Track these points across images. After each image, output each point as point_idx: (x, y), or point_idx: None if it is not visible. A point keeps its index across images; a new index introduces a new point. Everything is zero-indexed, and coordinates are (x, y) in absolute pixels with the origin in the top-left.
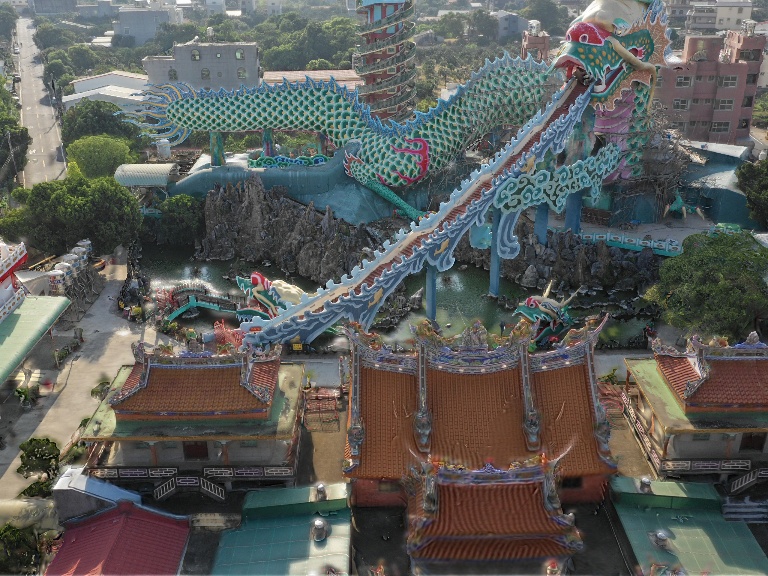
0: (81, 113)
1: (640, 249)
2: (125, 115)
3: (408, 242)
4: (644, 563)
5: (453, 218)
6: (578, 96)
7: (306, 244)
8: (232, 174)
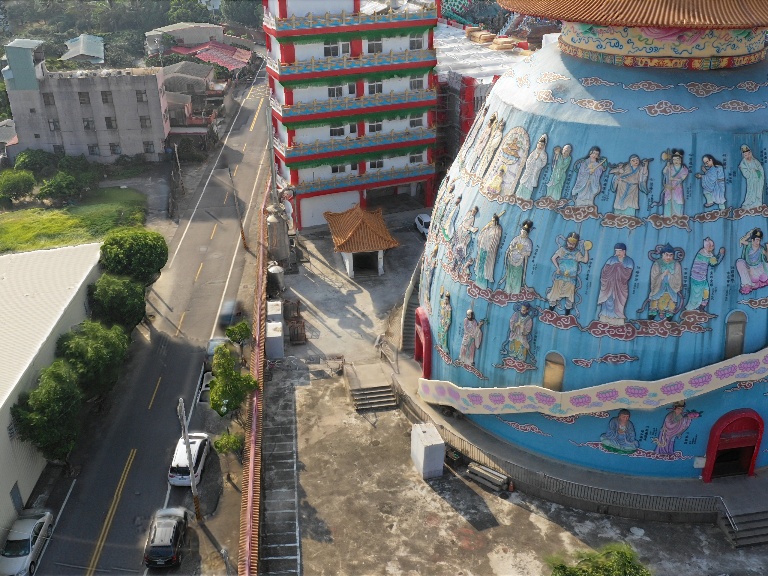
0: None
1: None
2: (215, 5)
3: (514, 20)
4: None
5: None
6: None
7: None
8: None
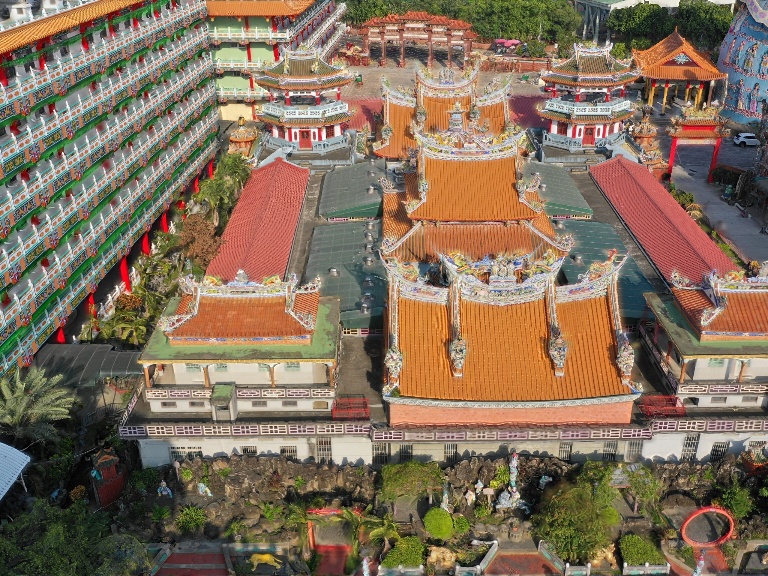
0: None
1: None
2: None
3: None
4: (386, 288)
5: None
6: None
7: None
8: None
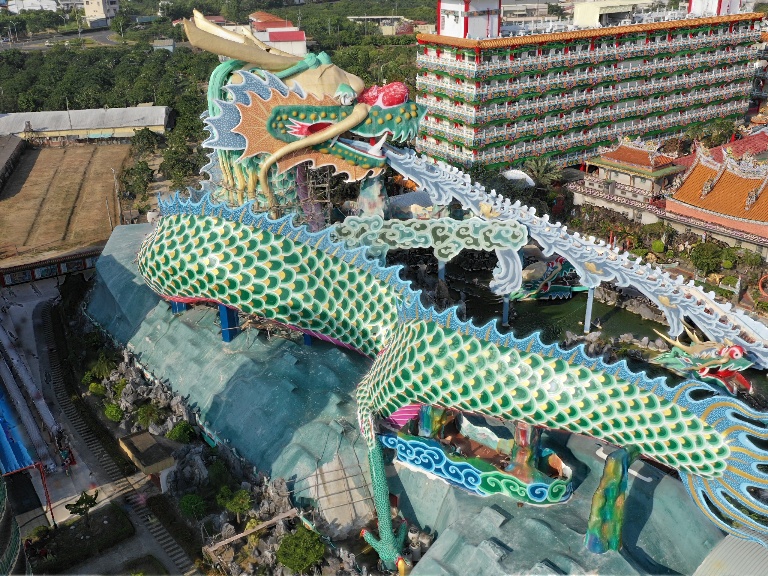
0: None
1: None
2: None
3: None
4: None
5: None
6: None
7: None
8: None
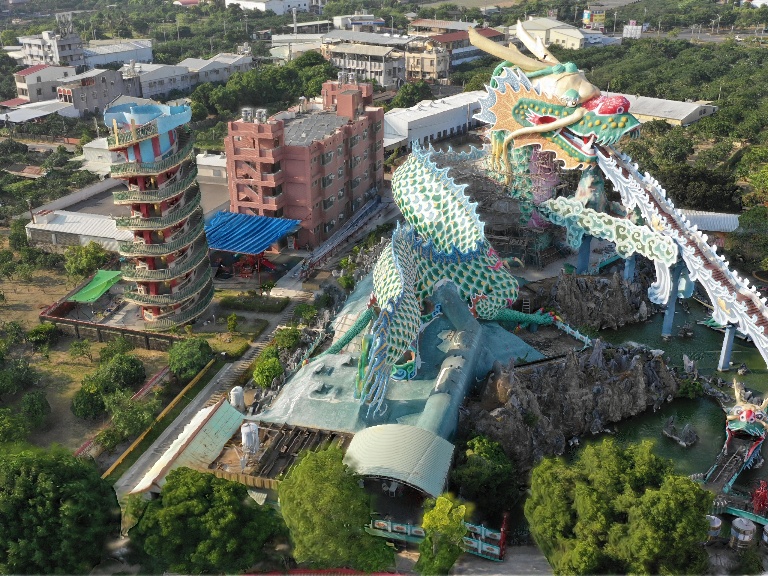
0: (17, 503)
1: (614, 259)
2: None
3: None
4: None
5: (715, 279)
6: (624, 156)
7: (604, 389)
8: (461, 383)
